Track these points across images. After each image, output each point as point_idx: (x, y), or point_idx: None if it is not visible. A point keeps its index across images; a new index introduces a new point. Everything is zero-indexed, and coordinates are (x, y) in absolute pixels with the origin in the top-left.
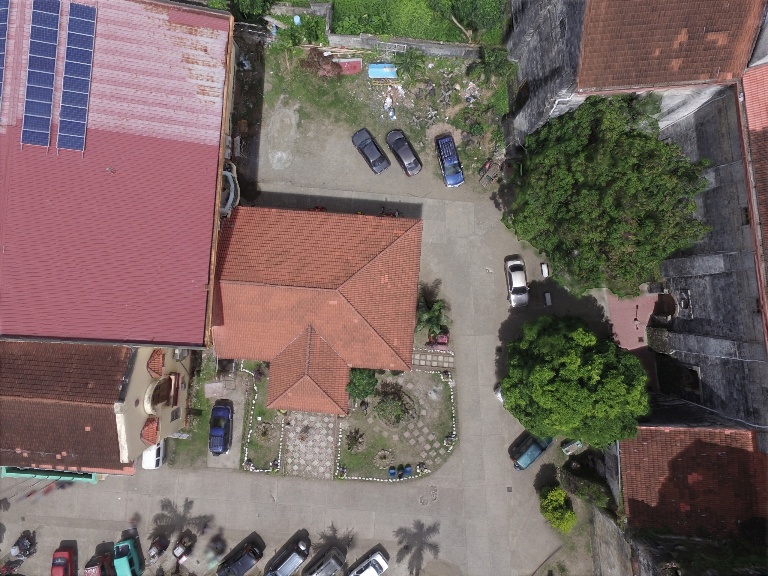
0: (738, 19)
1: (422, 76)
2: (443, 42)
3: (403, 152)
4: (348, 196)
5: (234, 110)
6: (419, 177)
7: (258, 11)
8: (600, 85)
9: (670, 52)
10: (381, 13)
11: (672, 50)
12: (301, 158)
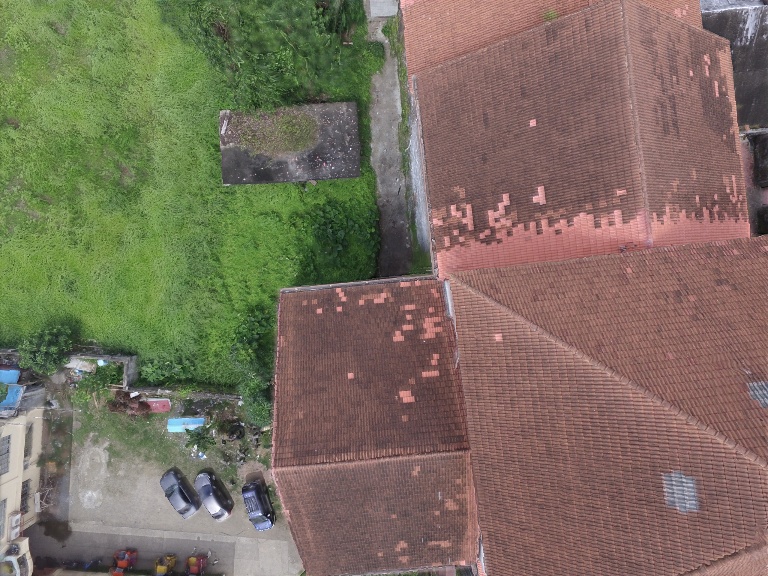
0: (455, 533)
1: (231, 415)
2: (243, 397)
3: (210, 499)
4: (160, 536)
5: (42, 450)
6: (231, 515)
7: (52, 371)
8: (330, 574)
9: (393, 553)
10: (184, 360)
11: (395, 552)
12: (112, 497)
